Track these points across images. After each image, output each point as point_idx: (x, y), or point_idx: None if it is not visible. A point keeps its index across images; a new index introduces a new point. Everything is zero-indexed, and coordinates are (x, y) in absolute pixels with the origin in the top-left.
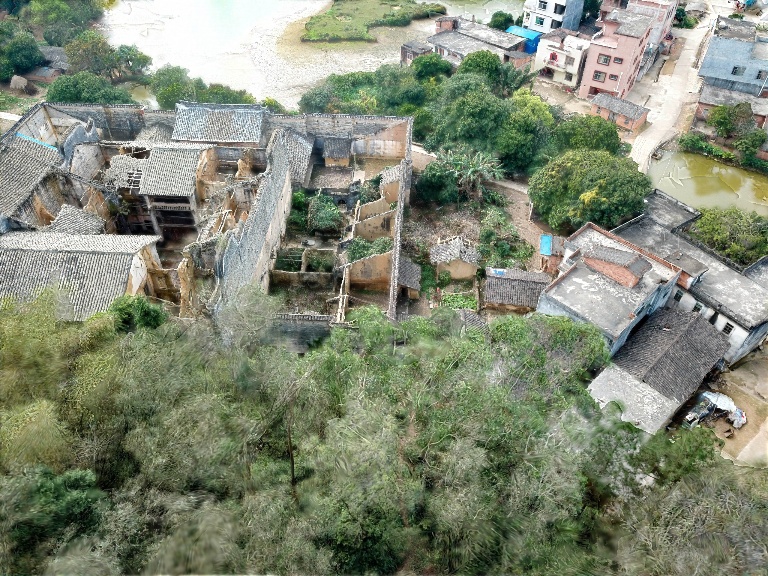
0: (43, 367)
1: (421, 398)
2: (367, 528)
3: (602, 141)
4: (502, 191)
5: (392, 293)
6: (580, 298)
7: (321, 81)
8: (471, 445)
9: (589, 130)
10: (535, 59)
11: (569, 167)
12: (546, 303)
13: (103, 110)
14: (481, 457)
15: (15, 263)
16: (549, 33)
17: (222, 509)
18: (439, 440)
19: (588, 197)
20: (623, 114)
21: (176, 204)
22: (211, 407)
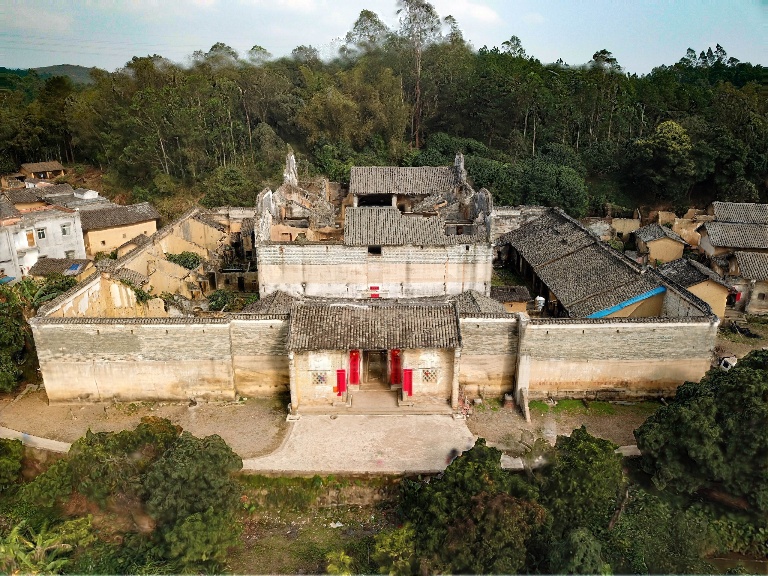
0: None
1: None
2: None
3: None
4: None
5: None
6: None
7: None
8: None
9: None
10: None
11: None
12: None
13: None
14: None
15: None
16: None
17: None
18: None
19: None
20: None
21: None
22: None
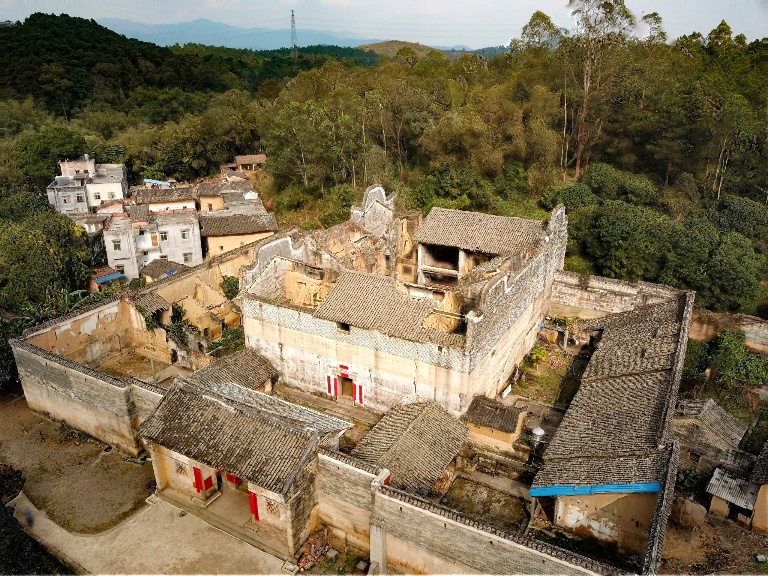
0: None
1: None
2: None
3: None
4: None
5: None
6: None
7: None
8: None
9: None
10: None
11: None
12: None
13: None
14: None
15: None
16: None
17: None
18: None
19: (82, 228)
20: None
21: None
22: None
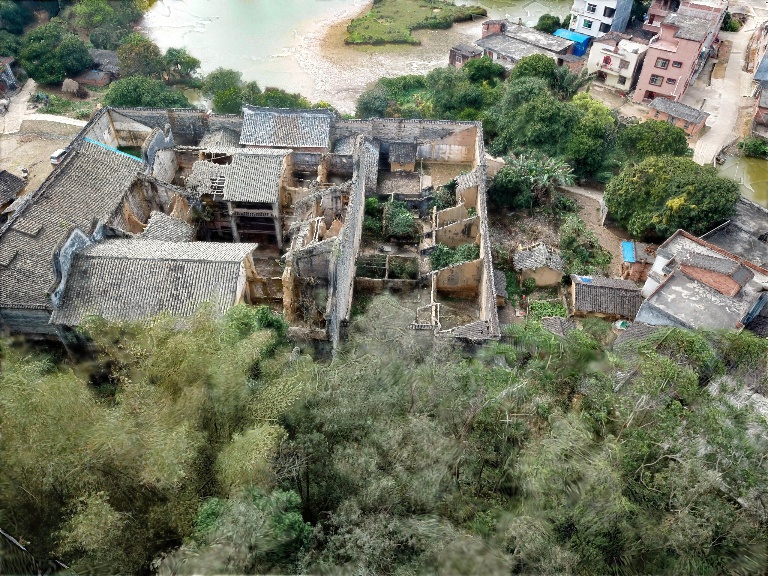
0: (225, 384)
1: (634, 418)
2: (586, 552)
3: (670, 146)
4: (570, 196)
5: (492, 302)
6: (683, 307)
7: (370, 84)
8: (701, 468)
9: (657, 135)
10: (587, 62)
11: (651, 173)
12: (648, 312)
13: (167, 114)
14: (717, 480)
15: (121, 272)
16: (603, 36)
17: (457, 534)
18: (655, 461)
19: (677, 204)
20: (683, 118)
21: (258, 210)
22: (425, 427)
